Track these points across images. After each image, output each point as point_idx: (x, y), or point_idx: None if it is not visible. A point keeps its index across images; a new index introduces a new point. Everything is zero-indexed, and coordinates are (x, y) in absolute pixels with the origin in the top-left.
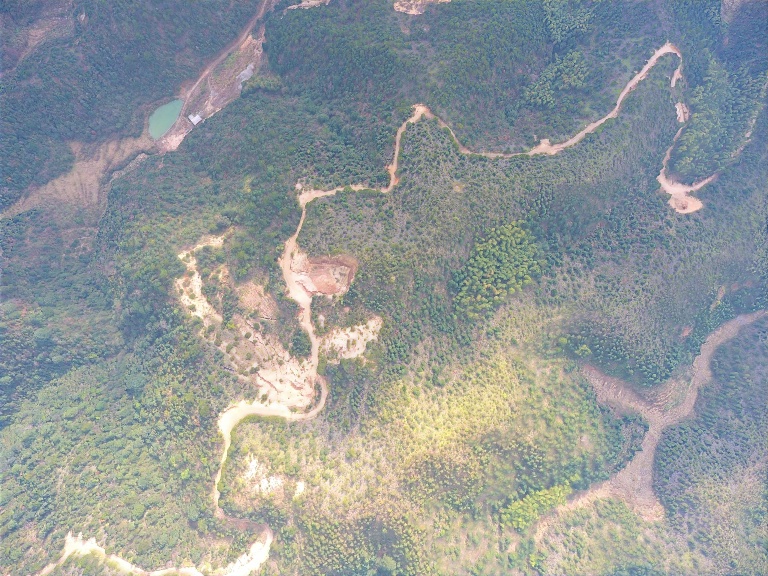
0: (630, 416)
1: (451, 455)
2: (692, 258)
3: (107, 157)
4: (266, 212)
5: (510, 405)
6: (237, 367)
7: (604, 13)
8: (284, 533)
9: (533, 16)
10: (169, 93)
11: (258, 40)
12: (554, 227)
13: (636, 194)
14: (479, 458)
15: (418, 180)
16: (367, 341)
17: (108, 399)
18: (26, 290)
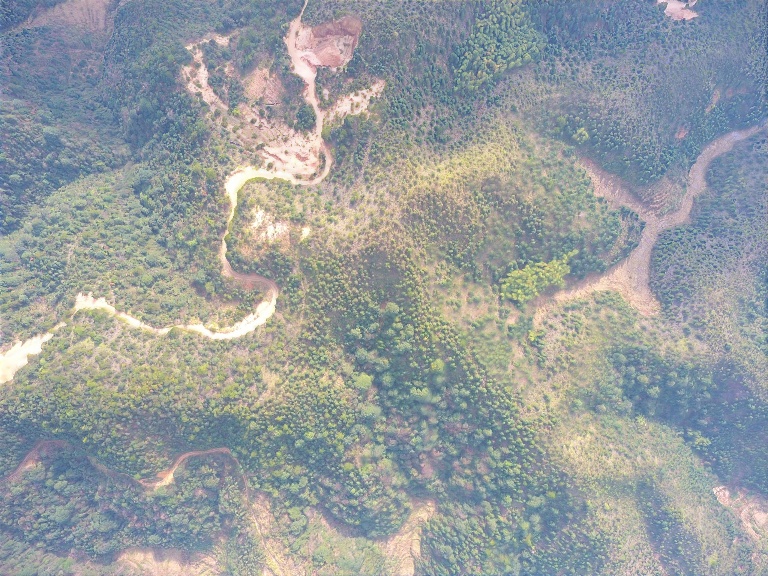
0: None
1: (453, 194)
2: (687, 51)
3: None
4: (271, 2)
5: (510, 160)
6: (243, 144)
7: None
8: (290, 281)
9: None
10: None
11: None
12: (553, 18)
13: None
14: (480, 205)
15: None
16: None
17: (116, 195)
18: (35, 94)
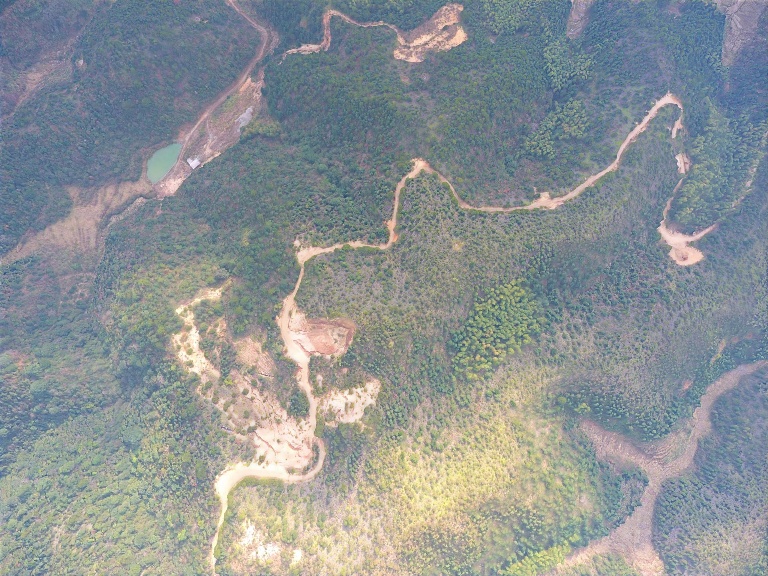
0: (630, 472)
1: (449, 525)
2: (692, 314)
3: (105, 201)
4: (264, 267)
5: (509, 471)
6: (234, 426)
7: (605, 60)
8: None
9: (533, 64)
10: (167, 137)
11: (257, 83)
12: (554, 283)
13: (636, 247)
14: (477, 526)
15: (417, 239)
16: (365, 405)
17: (105, 452)
18: (23, 341)
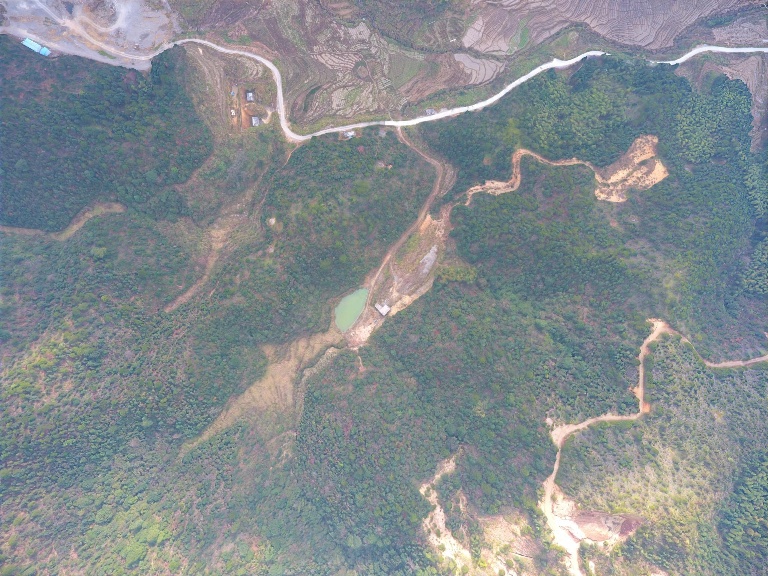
0: None
1: None
2: None
3: (298, 356)
4: (510, 443)
5: None
6: None
7: None
8: None
9: None
10: (356, 285)
11: (439, 221)
12: None
13: None
14: None
15: (678, 413)
16: None
17: None
18: (249, 520)
